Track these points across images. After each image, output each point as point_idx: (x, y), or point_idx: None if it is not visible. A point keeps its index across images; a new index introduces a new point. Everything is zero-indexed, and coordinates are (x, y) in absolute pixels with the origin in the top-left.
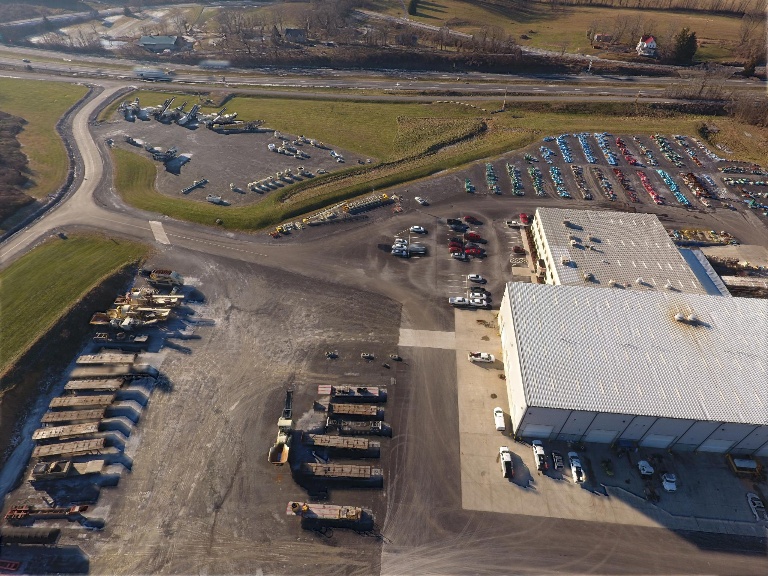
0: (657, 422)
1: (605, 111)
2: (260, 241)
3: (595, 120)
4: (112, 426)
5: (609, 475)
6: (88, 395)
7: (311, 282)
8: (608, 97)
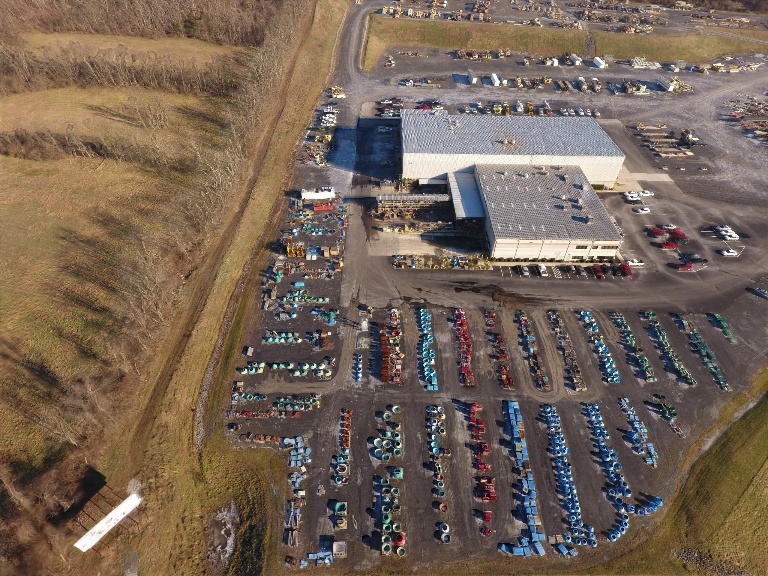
0: None
1: None
2: None
3: None
4: None
5: None
6: None
7: (767, 205)
8: None
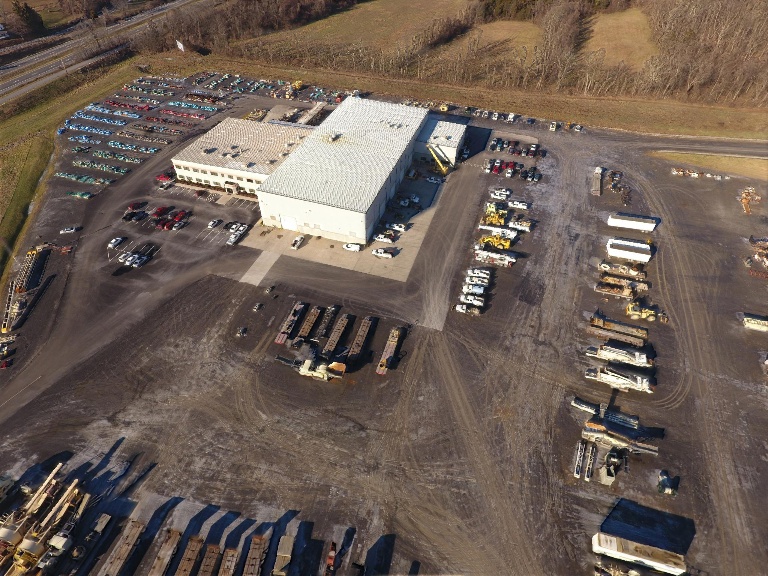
0: (391, 177)
1: (55, 92)
2: (0, 383)
3: (62, 101)
4: (233, 543)
5: (404, 217)
6: None
7: (127, 337)
8: (39, 81)
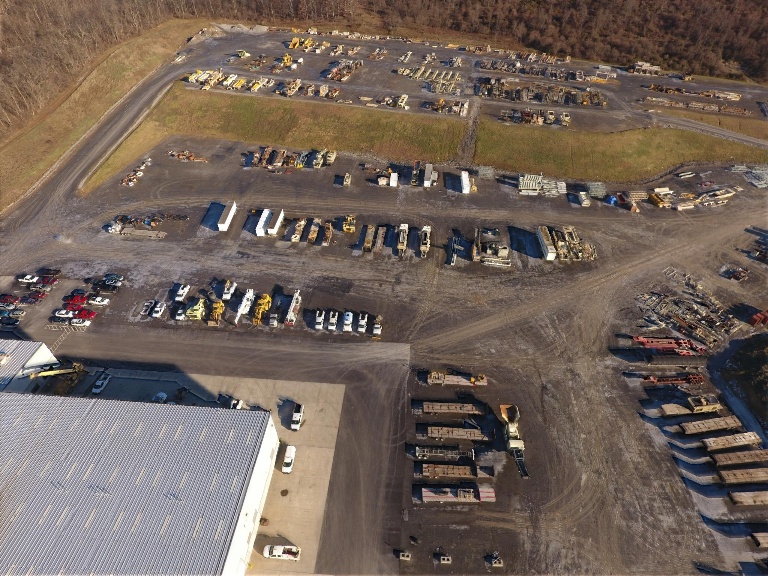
0: None
1: None
2: None
3: None
4: (695, 453)
5: None
6: (759, 489)
7: None
8: None
